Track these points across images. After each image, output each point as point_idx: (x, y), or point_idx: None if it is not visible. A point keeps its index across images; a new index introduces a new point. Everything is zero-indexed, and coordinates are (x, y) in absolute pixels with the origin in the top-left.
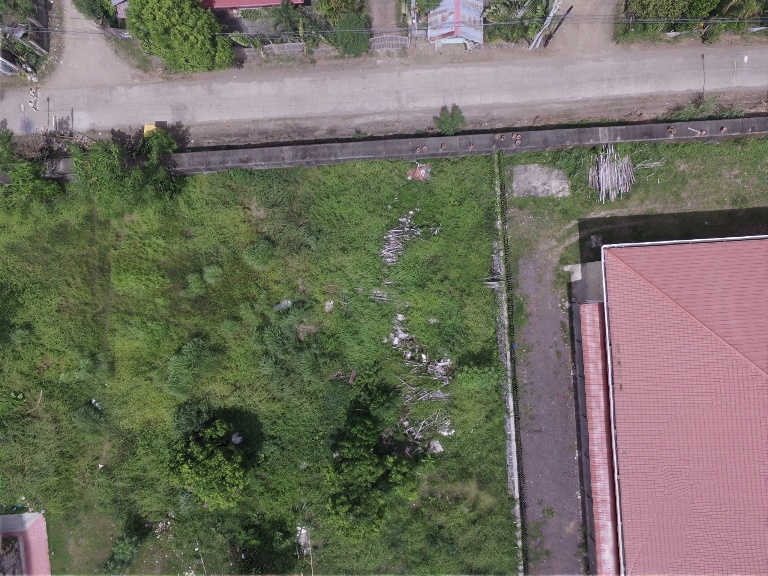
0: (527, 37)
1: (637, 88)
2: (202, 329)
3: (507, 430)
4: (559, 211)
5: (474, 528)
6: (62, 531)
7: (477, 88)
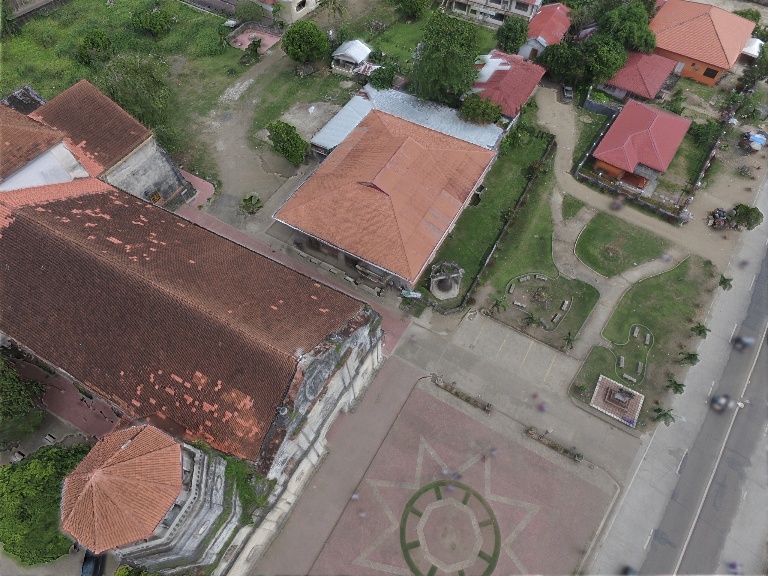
0: None
1: None
2: None
3: (190, 7)
4: None
5: None
6: None
7: None
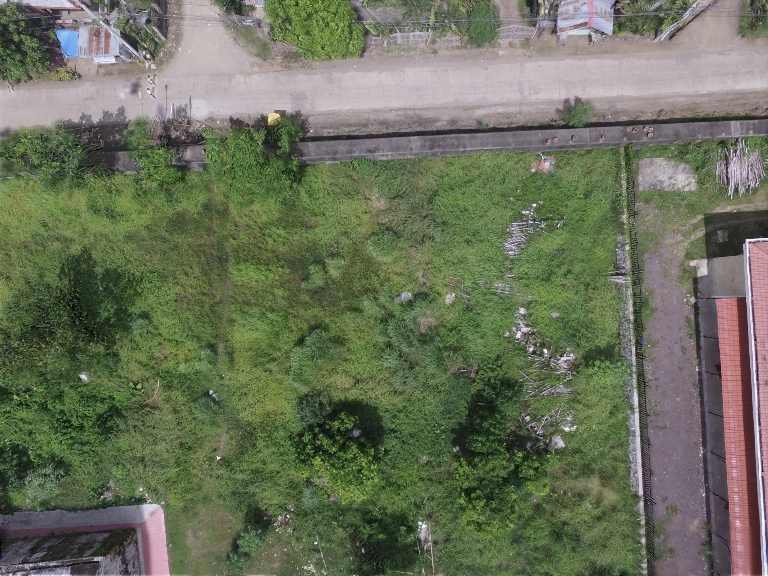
0: (658, 29)
1: (762, 82)
2: (321, 320)
3: (631, 426)
4: (685, 205)
5: (600, 525)
6: (180, 523)
7: (600, 80)
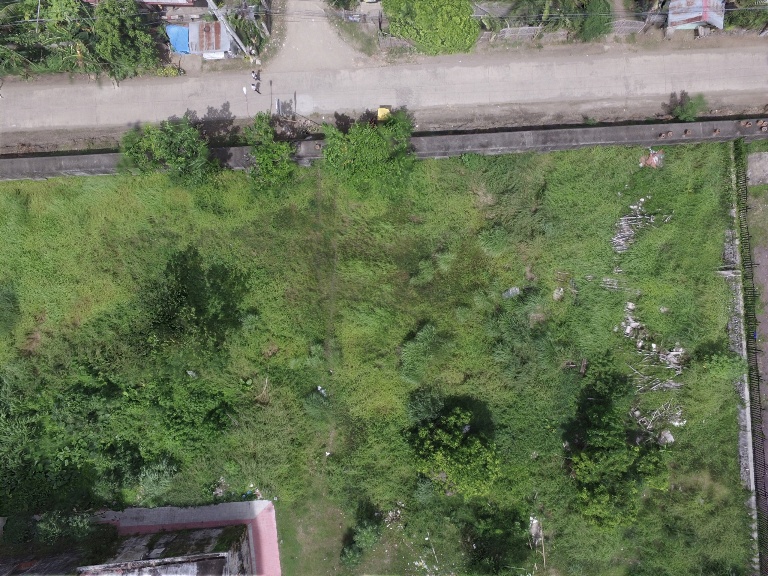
0: None
1: None
2: (429, 316)
3: (741, 421)
4: None
5: (714, 519)
6: (290, 519)
7: (707, 75)
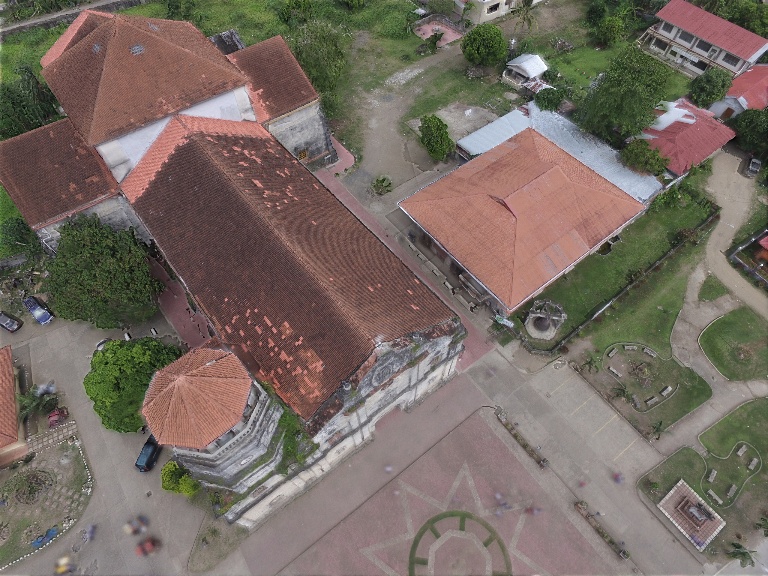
0: None
1: None
2: None
3: None
4: None
5: None
6: None
7: None
